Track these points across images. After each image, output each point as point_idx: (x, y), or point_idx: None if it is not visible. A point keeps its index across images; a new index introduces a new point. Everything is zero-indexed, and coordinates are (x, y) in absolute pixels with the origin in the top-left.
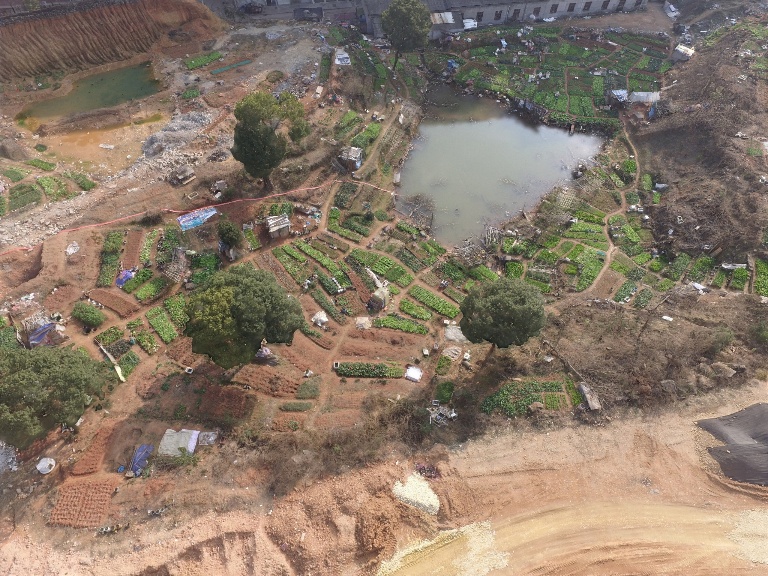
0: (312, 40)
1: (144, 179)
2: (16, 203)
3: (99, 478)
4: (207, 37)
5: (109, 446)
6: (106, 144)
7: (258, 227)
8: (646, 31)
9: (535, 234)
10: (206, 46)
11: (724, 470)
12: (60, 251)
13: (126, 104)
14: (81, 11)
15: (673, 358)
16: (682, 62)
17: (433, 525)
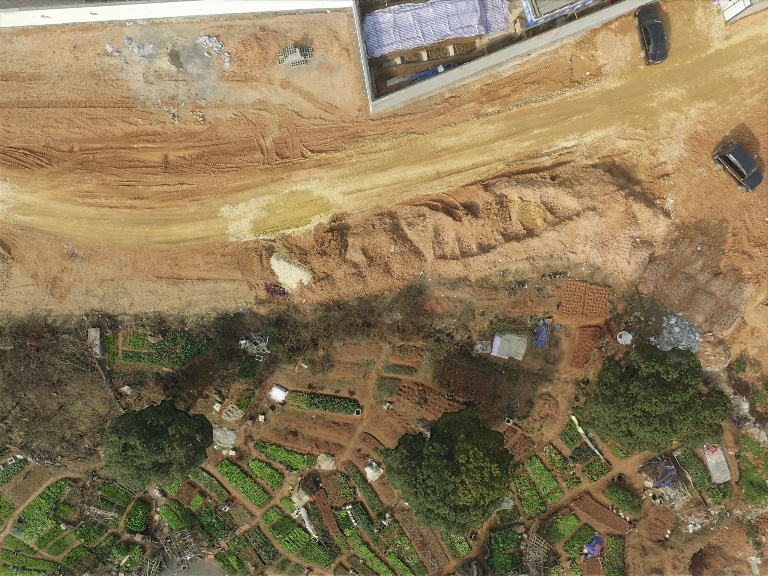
0: None
1: None
2: None
3: (575, 320)
4: None
5: (573, 350)
6: None
7: None
8: None
9: (93, 571)
10: None
11: None
12: None
13: None
14: None
15: None
16: None
17: (279, 244)
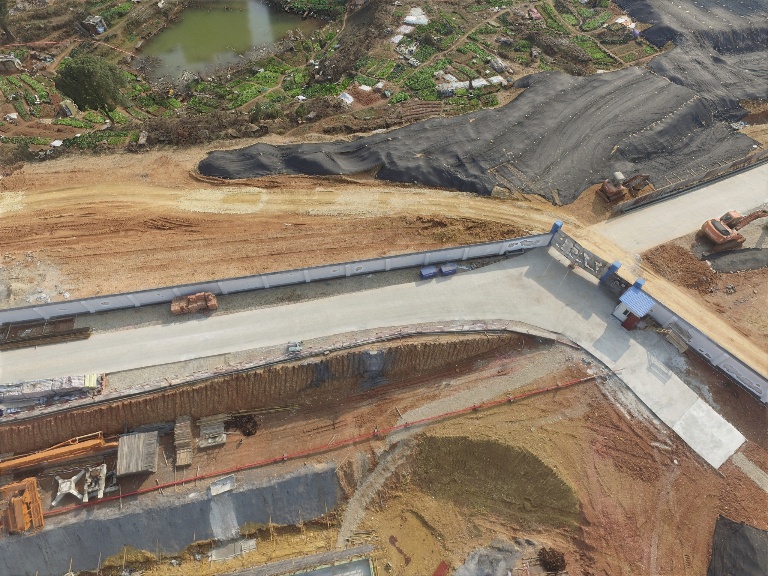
0: None
1: None
2: None
3: None
4: None
5: None
6: None
7: None
8: None
9: None
10: None
11: (200, 170)
12: None
13: None
14: None
15: (218, 120)
16: None
17: None
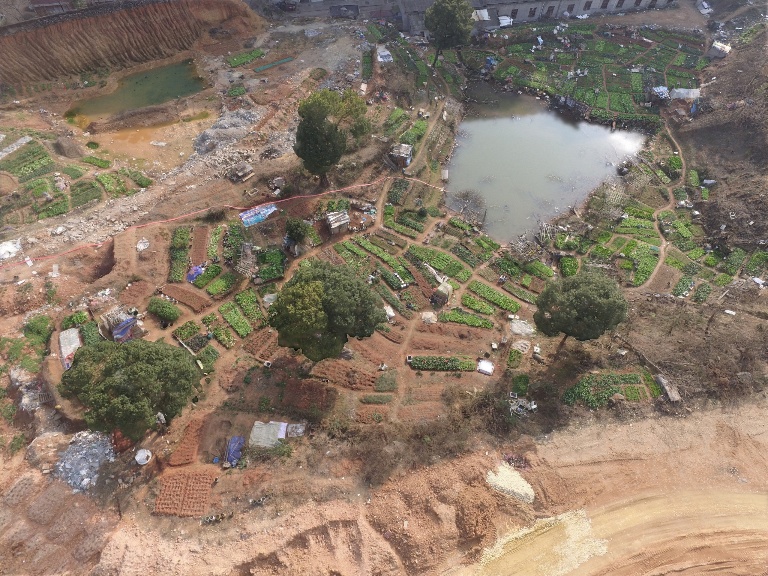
0: (351, 37)
1: (201, 176)
2: (78, 200)
3: (198, 469)
4: (247, 35)
5: (201, 438)
6: (157, 141)
7: (317, 223)
8: (681, 28)
9: (587, 230)
10: (247, 44)
11: None
12: (131, 247)
13: (173, 102)
14: (127, 9)
15: (747, 351)
16: (719, 59)
17: (530, 513)
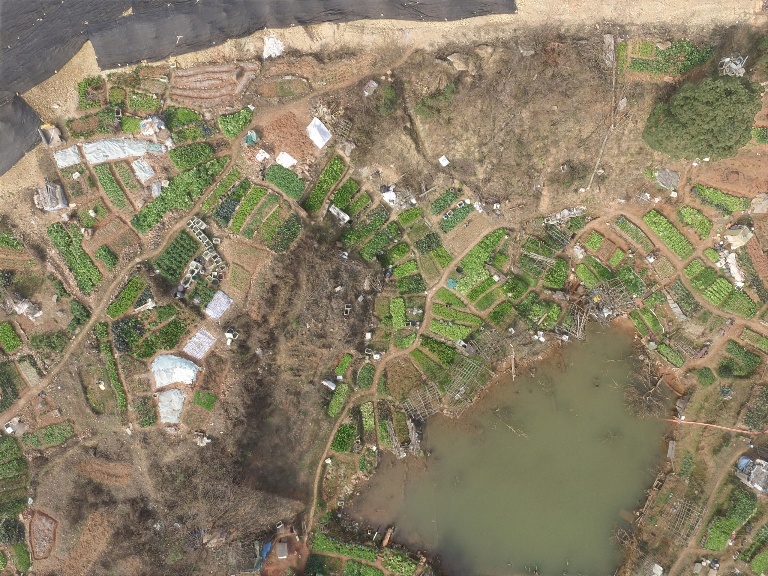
0: None
1: None
2: None
3: None
4: None
5: None
6: None
7: None
8: None
9: None
10: None
11: None
12: None
13: None
14: None
15: None
16: None
17: None
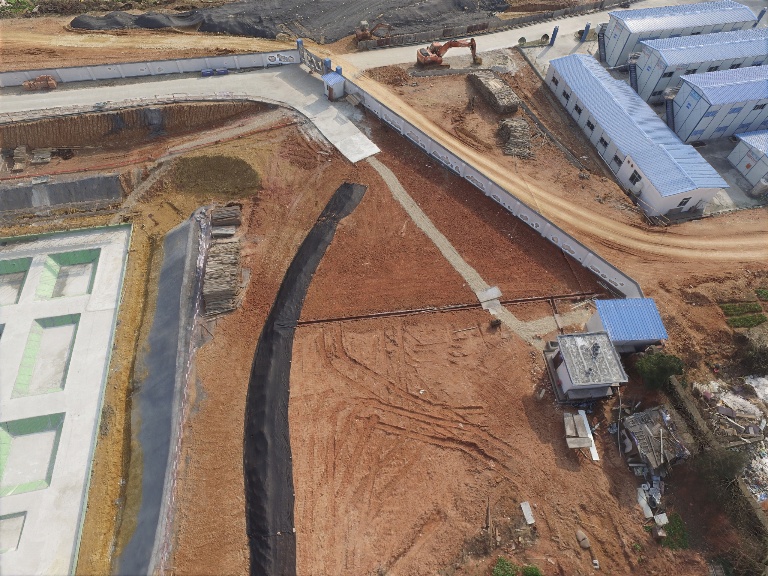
0: None
1: None
2: None
3: None
4: None
5: None
6: None
7: None
8: None
9: None
10: None
11: (71, 25)
12: None
13: None
14: None
15: None
16: None
17: None
